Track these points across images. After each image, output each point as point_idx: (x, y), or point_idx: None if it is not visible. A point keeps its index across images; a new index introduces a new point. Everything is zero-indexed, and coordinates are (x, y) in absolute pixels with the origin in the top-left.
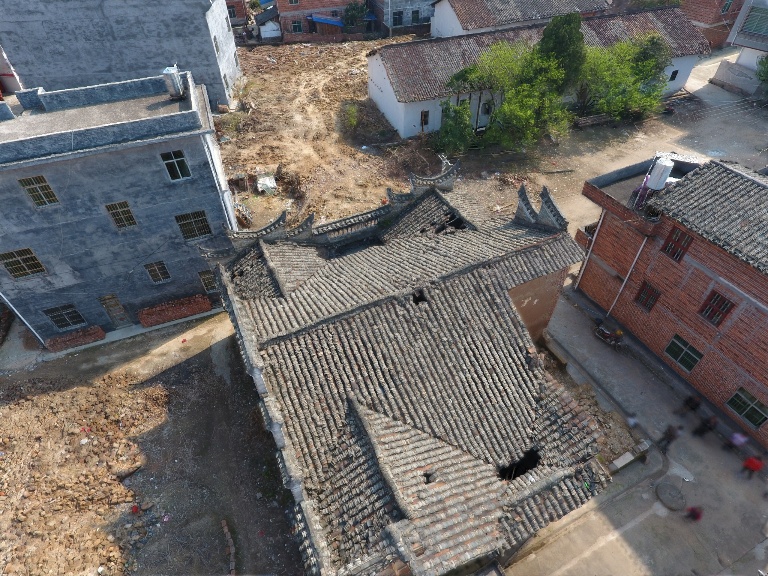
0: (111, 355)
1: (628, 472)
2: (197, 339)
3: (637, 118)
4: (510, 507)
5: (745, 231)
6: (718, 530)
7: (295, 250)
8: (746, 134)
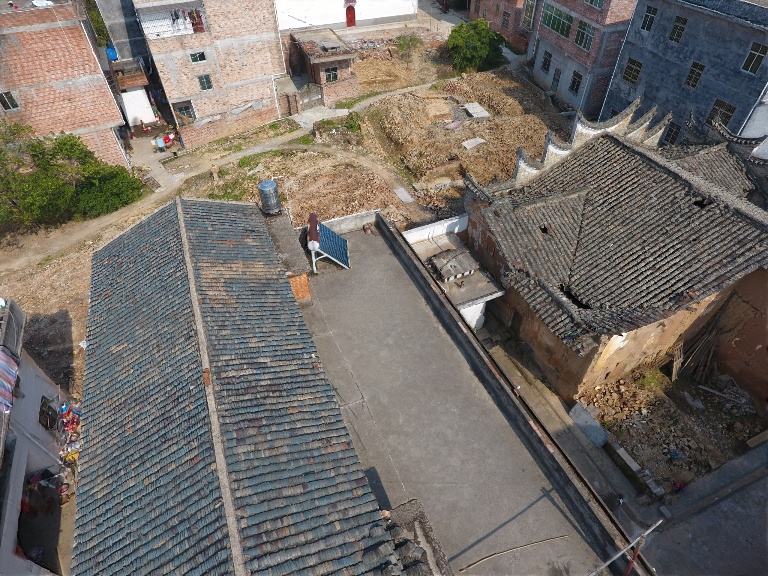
0: None
1: (620, 476)
2: None
3: None
4: (538, 282)
5: None
6: None
7: (736, 170)
8: None
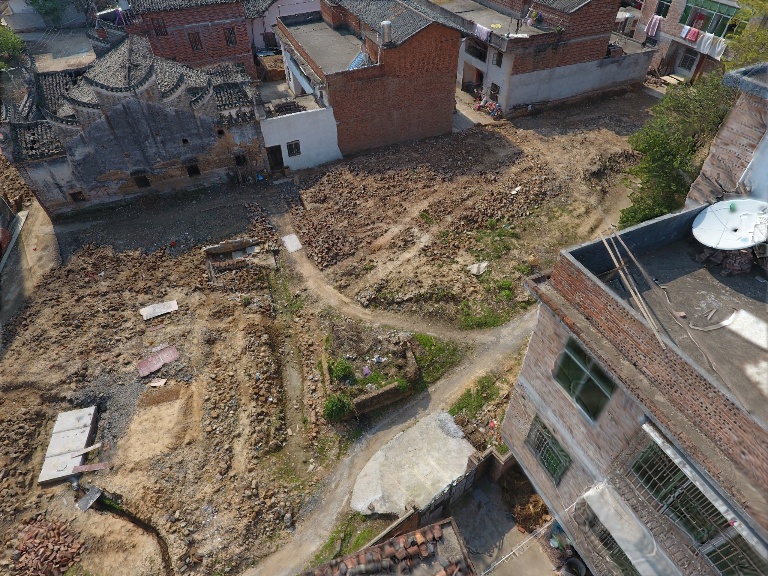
0: (10, 291)
1: None
2: (40, 242)
3: (16, 58)
4: None
5: (173, 1)
6: (276, 98)
7: None
8: (78, 39)
